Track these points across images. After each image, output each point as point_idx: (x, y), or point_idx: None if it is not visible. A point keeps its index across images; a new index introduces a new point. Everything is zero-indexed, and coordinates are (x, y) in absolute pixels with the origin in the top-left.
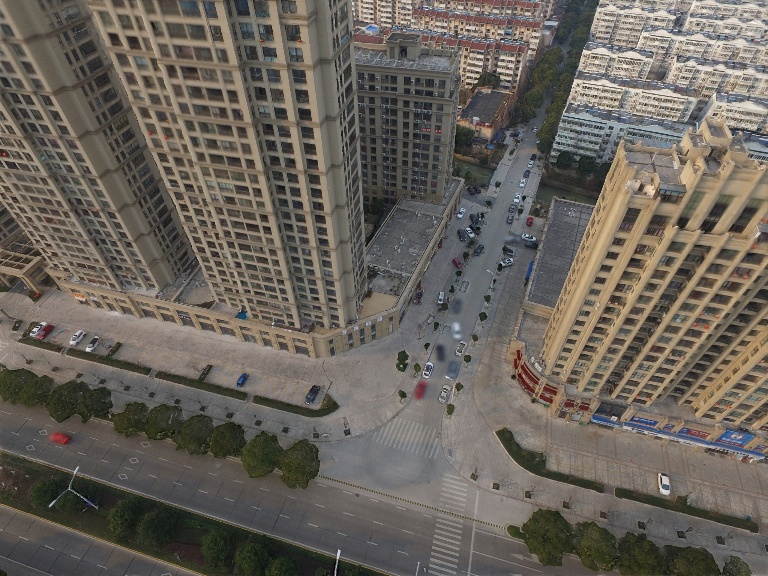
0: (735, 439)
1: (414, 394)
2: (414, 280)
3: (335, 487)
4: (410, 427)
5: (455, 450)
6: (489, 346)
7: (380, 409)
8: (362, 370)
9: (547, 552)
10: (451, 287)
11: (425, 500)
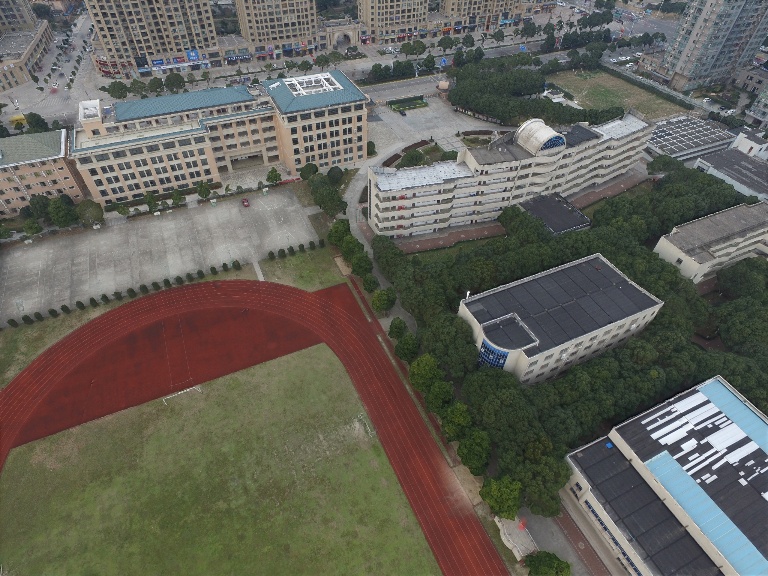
0: (194, 56)
1: (51, 93)
2: (27, 52)
3: (19, 121)
4: (52, 100)
5: (79, 98)
6: (88, 73)
7: (33, 100)
8: (16, 94)
9: (117, 91)
10: (56, 58)
11: (68, 111)
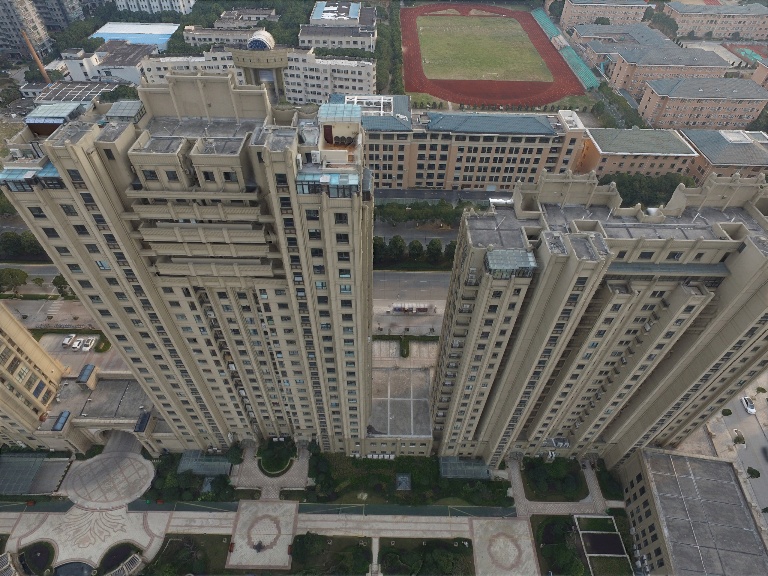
0: None
1: None
2: None
3: None
4: None
5: None
6: None
7: None
8: None
9: None
10: None
11: None
